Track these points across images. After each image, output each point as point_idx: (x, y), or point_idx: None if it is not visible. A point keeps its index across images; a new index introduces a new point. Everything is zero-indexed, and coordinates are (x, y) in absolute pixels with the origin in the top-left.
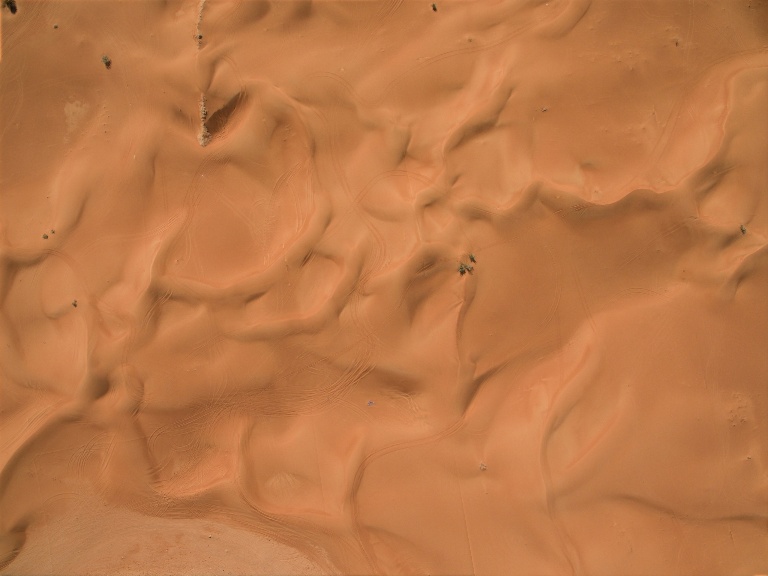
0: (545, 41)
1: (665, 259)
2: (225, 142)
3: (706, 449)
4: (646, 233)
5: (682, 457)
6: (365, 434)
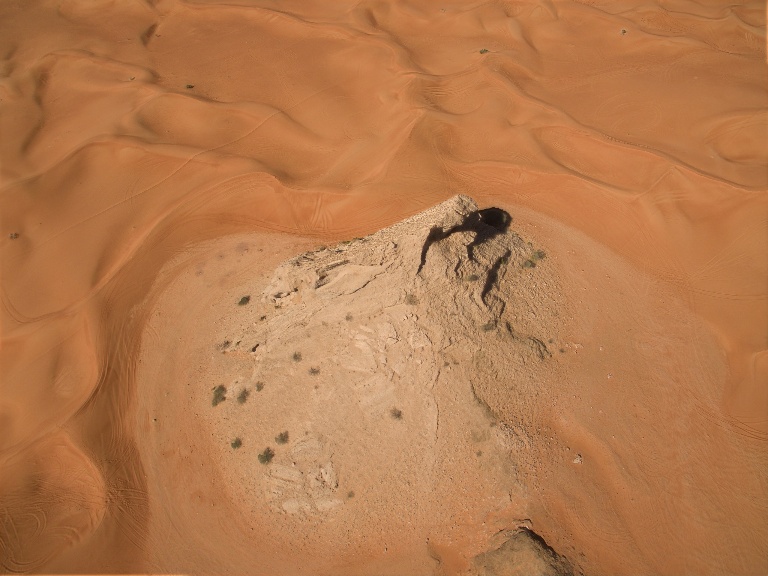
0: None
1: None
2: None
3: None
4: None
5: None
6: None
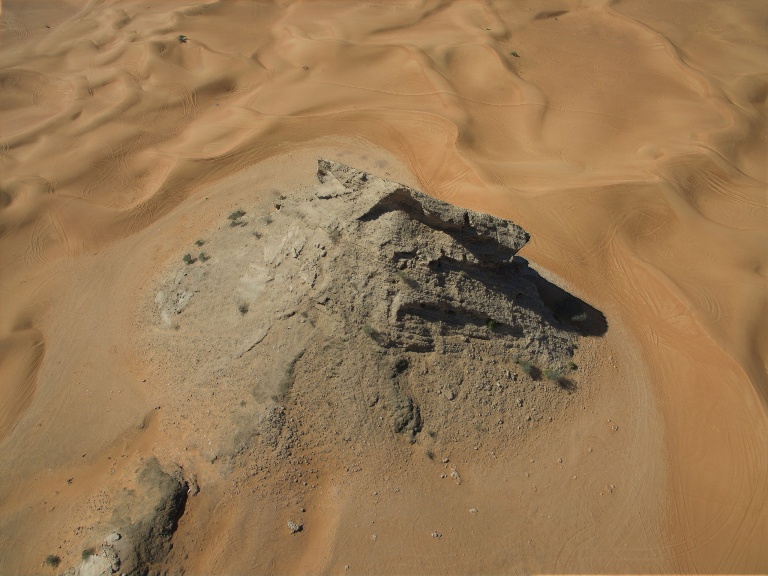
0: None
1: (271, 7)
2: None
3: (377, 13)
4: (250, 4)
5: None
6: None
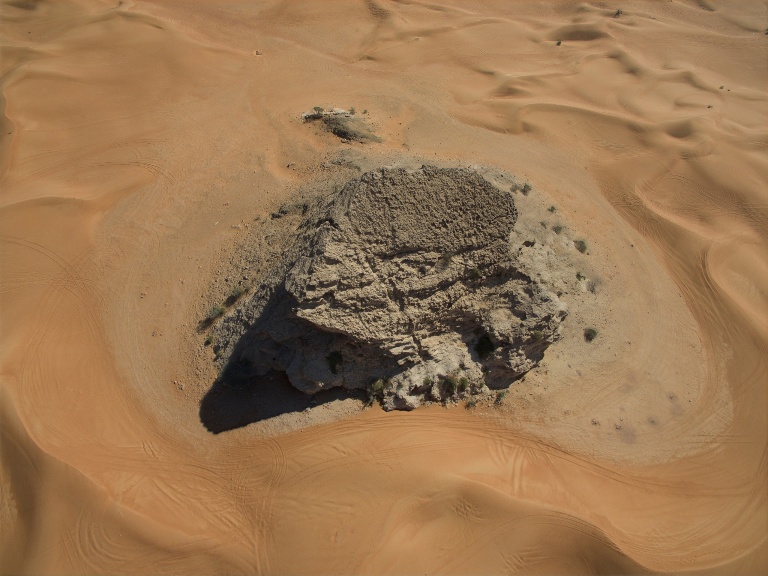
0: None
1: None
2: None
3: None
4: None
5: None
6: None
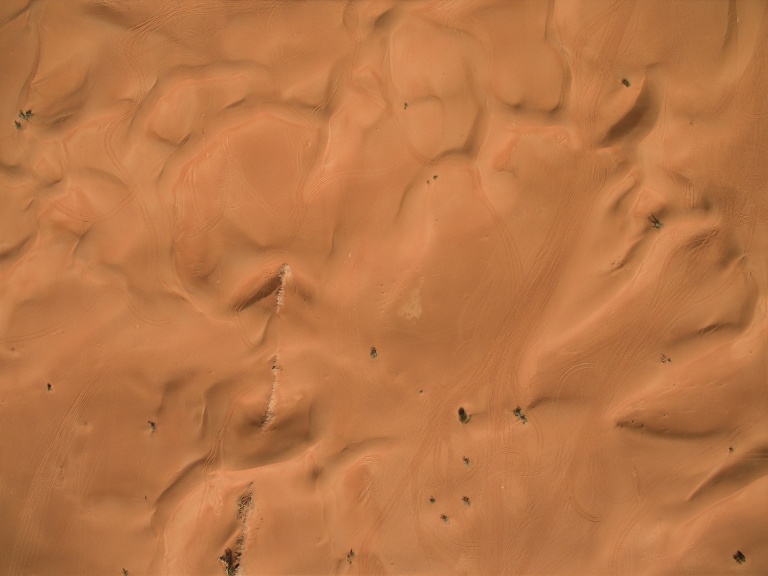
0: None
1: None
2: (265, 266)
3: None
4: None
5: None
6: None
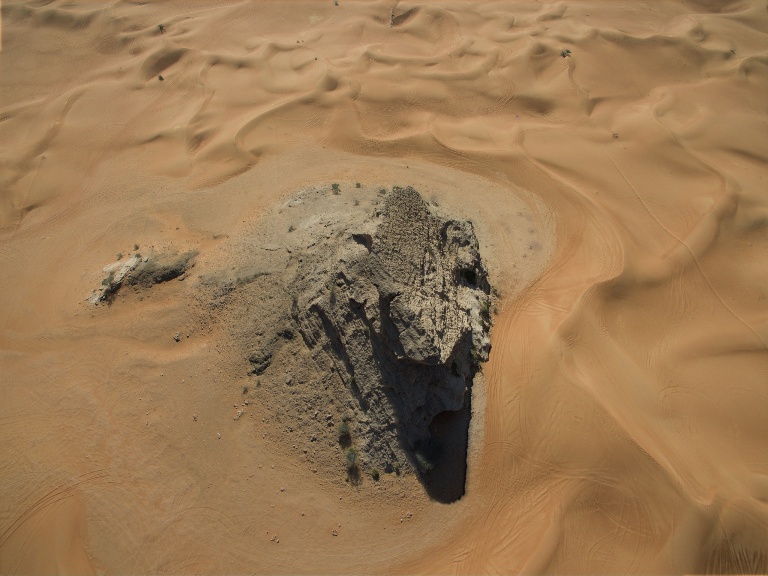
0: (578, 0)
1: (692, 69)
2: (404, 26)
3: None
4: (673, 56)
5: (765, 137)
6: (519, 124)
